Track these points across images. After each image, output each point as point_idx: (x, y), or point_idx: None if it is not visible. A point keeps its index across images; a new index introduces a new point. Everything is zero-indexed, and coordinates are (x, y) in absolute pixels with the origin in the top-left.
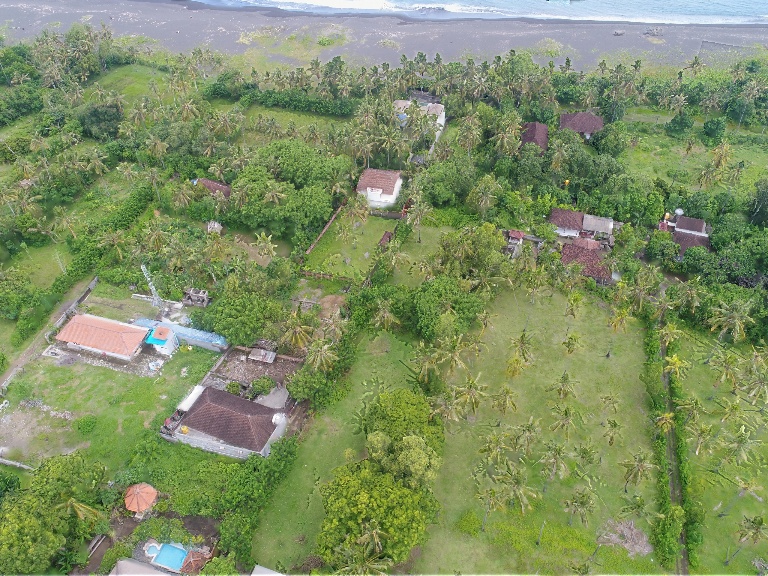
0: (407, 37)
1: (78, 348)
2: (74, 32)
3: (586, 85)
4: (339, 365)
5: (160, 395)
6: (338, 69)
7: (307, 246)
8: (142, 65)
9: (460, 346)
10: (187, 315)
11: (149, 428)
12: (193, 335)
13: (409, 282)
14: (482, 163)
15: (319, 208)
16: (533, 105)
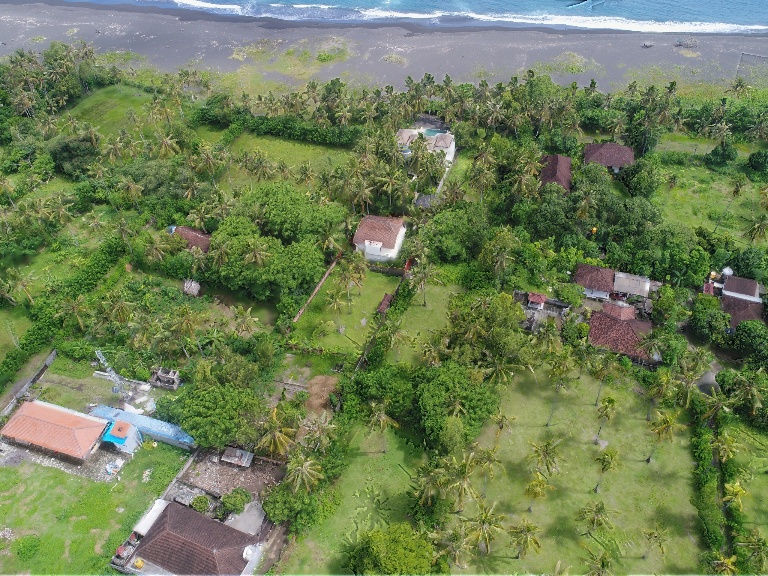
0: (414, 51)
1: (27, 443)
2: (53, 51)
3: (613, 107)
4: (326, 475)
5: (116, 508)
6: (337, 92)
7: (295, 312)
8: (127, 85)
9: (470, 466)
10: (154, 400)
11: (100, 555)
12: (158, 430)
13: (412, 358)
14: (497, 206)
15: (308, 269)
16: (554, 134)
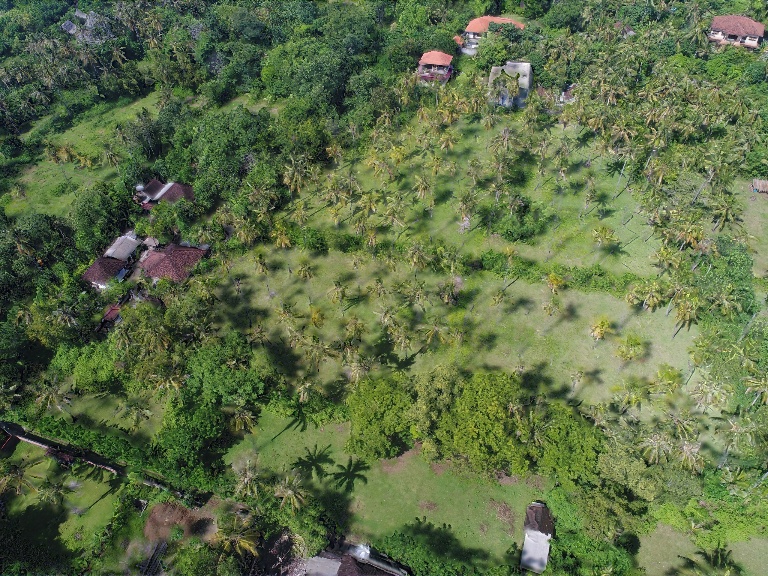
0: None
1: None
2: None
3: None
4: None
5: None
6: None
7: (28, 574)
8: None
9: None
10: None
11: None
12: None
13: (149, 431)
14: None
15: None
16: None
